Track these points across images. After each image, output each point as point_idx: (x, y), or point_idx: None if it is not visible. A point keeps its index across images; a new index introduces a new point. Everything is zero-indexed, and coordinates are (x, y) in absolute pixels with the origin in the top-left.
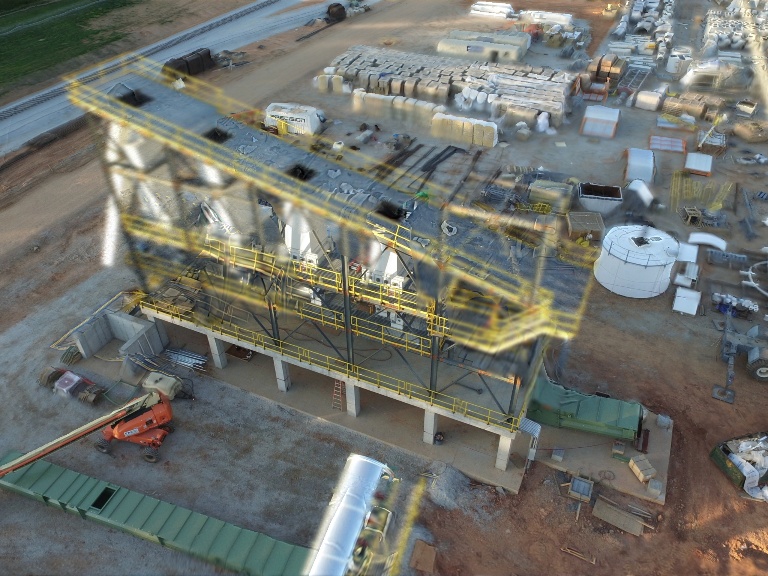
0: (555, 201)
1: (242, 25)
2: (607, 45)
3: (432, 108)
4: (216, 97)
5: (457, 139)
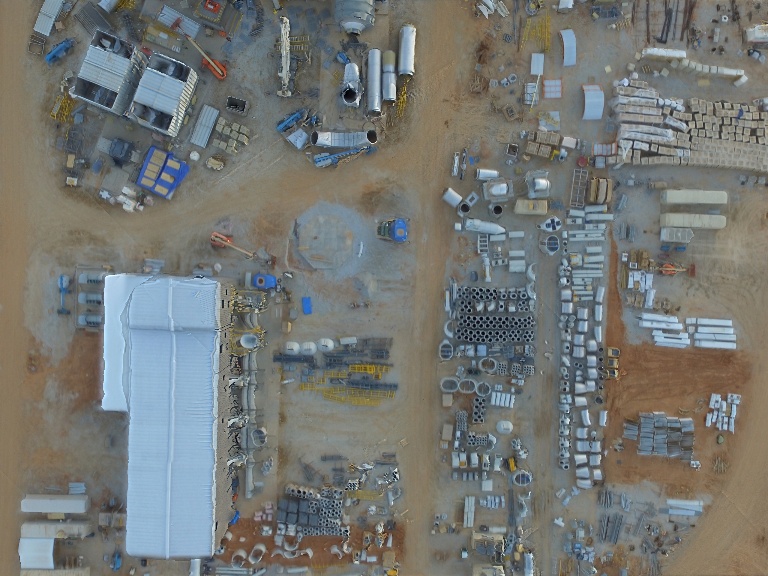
0: None
1: None
2: None
3: (691, 62)
4: None
5: None
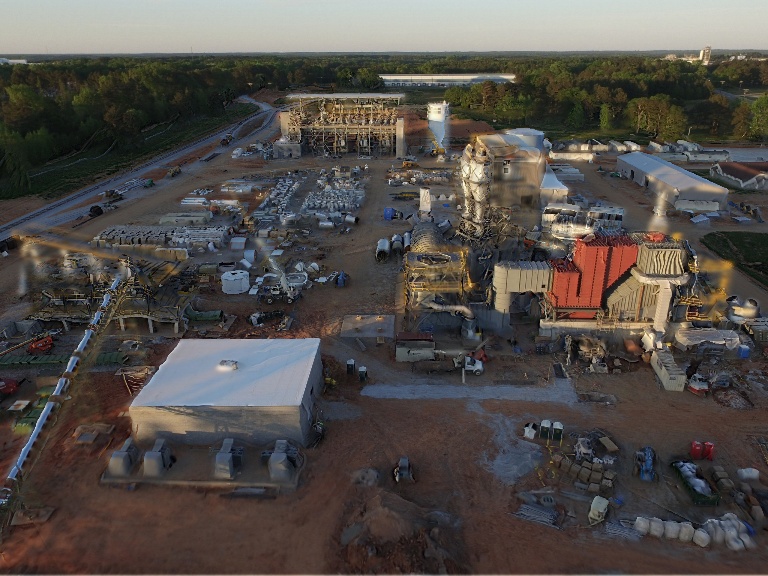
0: (210, 272)
1: (33, 223)
2: (253, 213)
3: (155, 247)
4: (30, 258)
5: (169, 258)
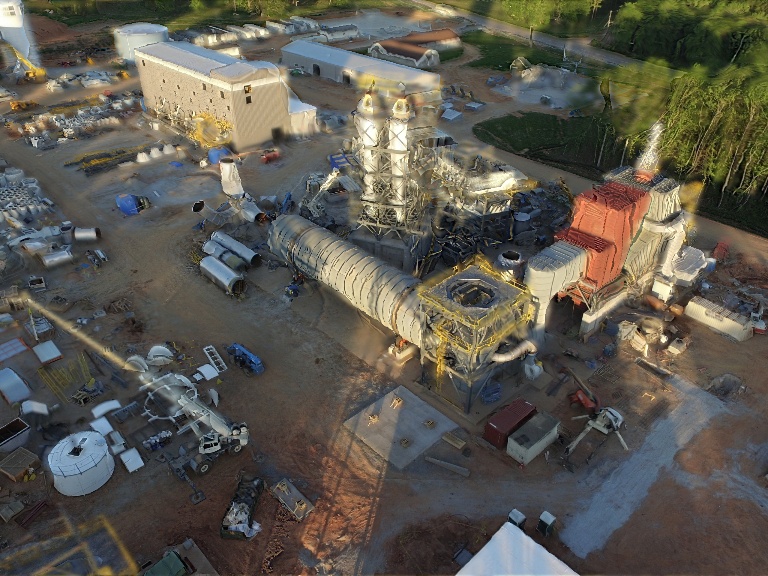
0: None
1: None
2: None
3: None
4: None
5: None
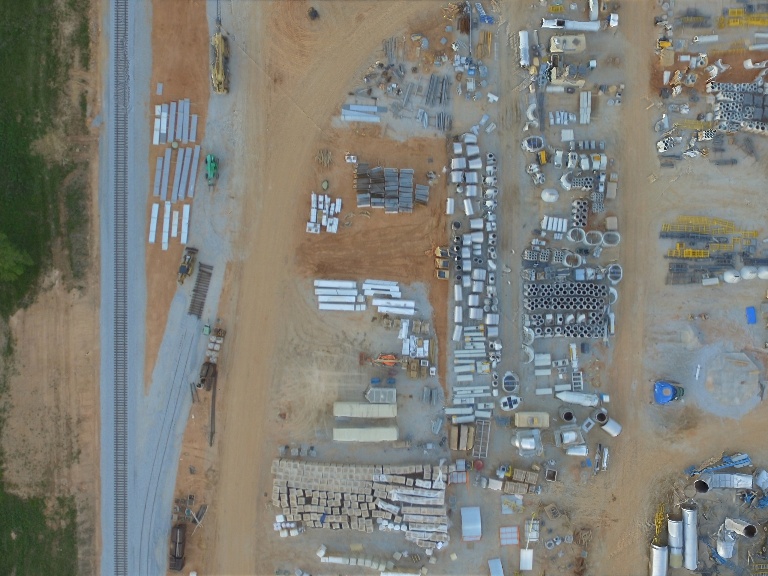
0: None
1: (142, 428)
2: (454, 371)
3: (377, 569)
4: (225, 574)
5: None
